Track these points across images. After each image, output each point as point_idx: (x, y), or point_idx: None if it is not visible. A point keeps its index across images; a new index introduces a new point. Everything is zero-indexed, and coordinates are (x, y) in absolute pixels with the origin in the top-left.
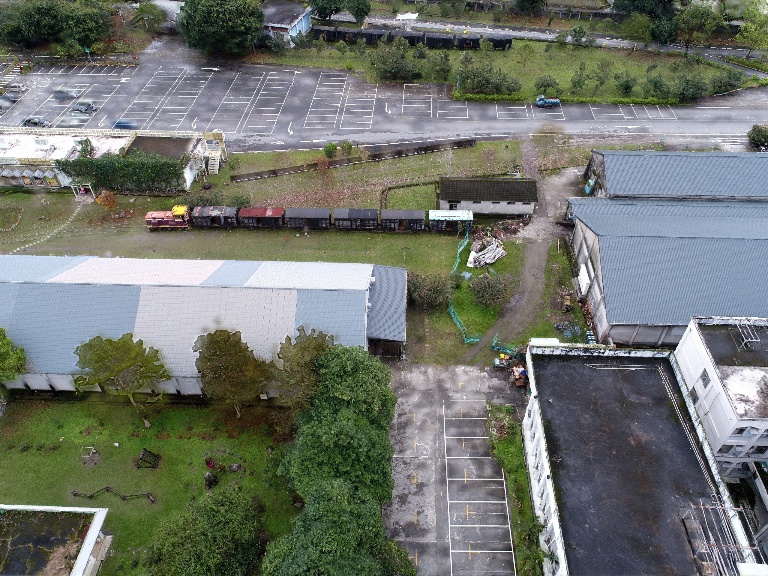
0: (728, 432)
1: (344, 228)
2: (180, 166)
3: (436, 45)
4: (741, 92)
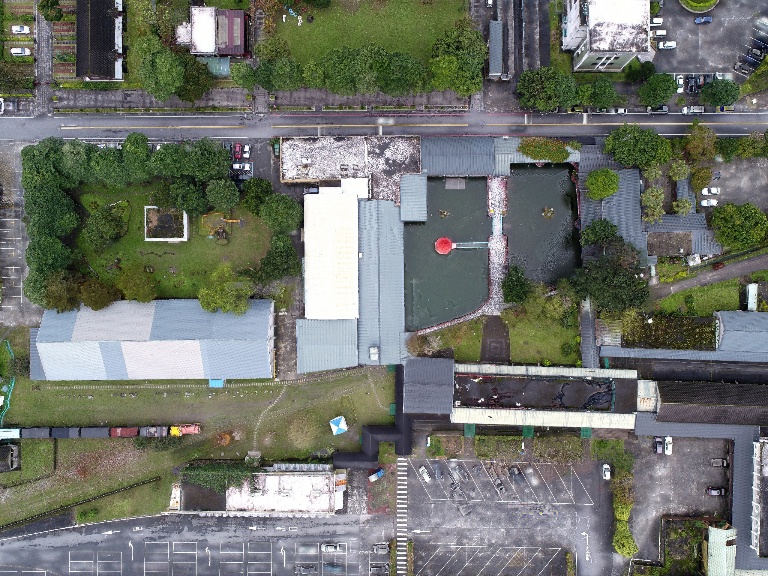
0: None
1: None
2: None
3: None
4: None
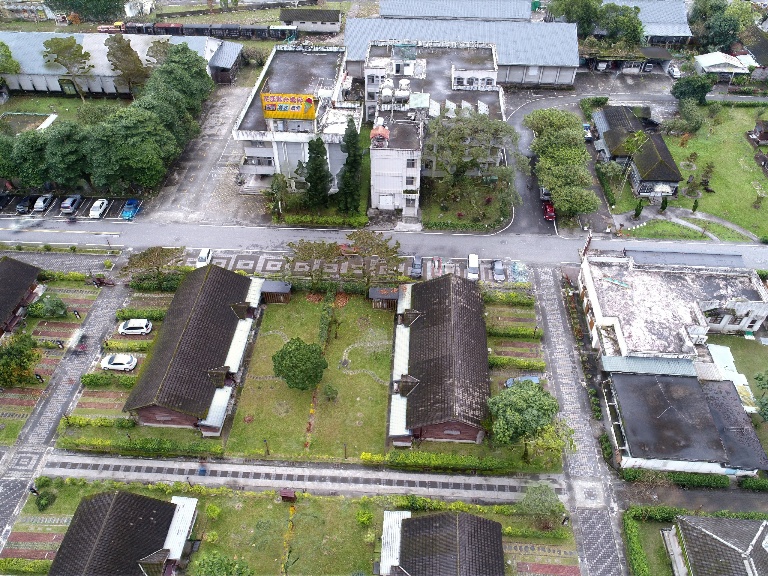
0: (365, 79)
1: (219, 36)
2: (122, 2)
3: None
4: None
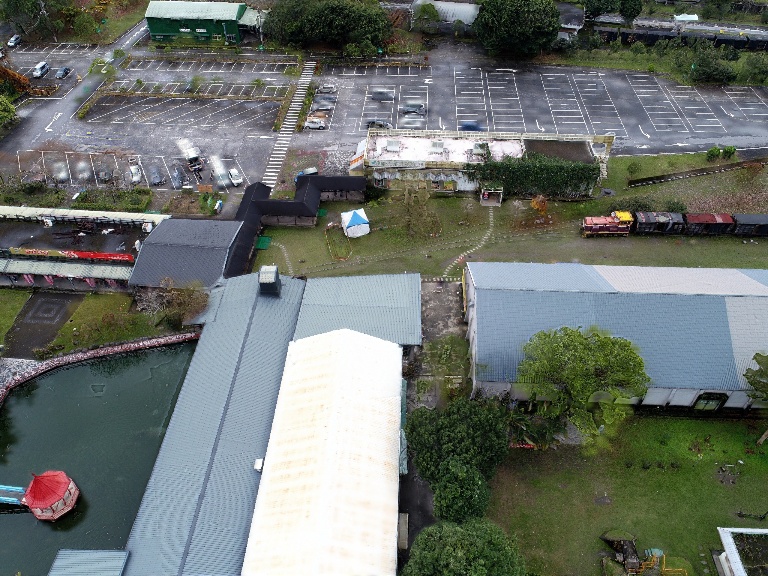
0: None
1: None
2: (598, 170)
3: (726, 47)
4: None
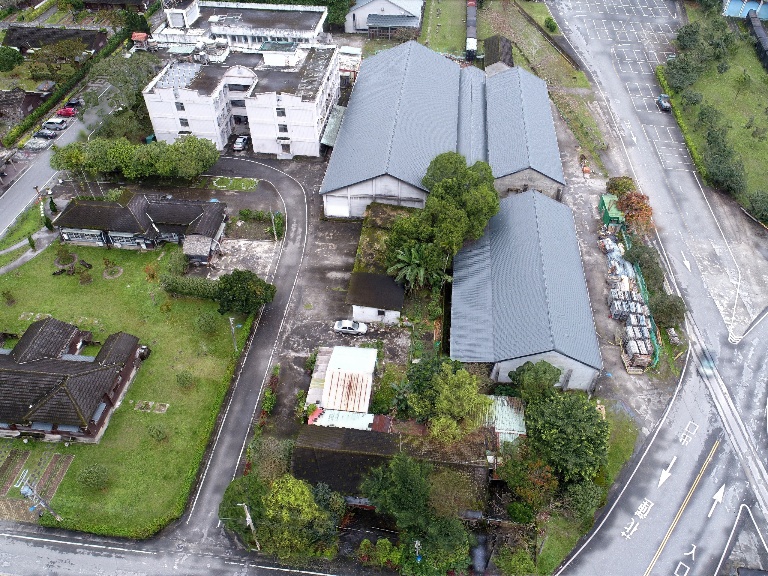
0: None
1: None
2: None
3: None
4: (764, 231)
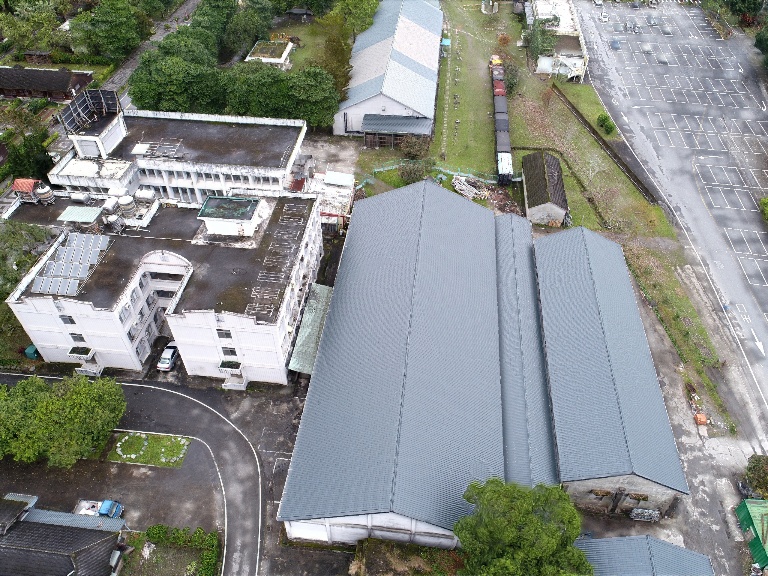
0: None
1: None
2: (540, 51)
3: None
4: None
